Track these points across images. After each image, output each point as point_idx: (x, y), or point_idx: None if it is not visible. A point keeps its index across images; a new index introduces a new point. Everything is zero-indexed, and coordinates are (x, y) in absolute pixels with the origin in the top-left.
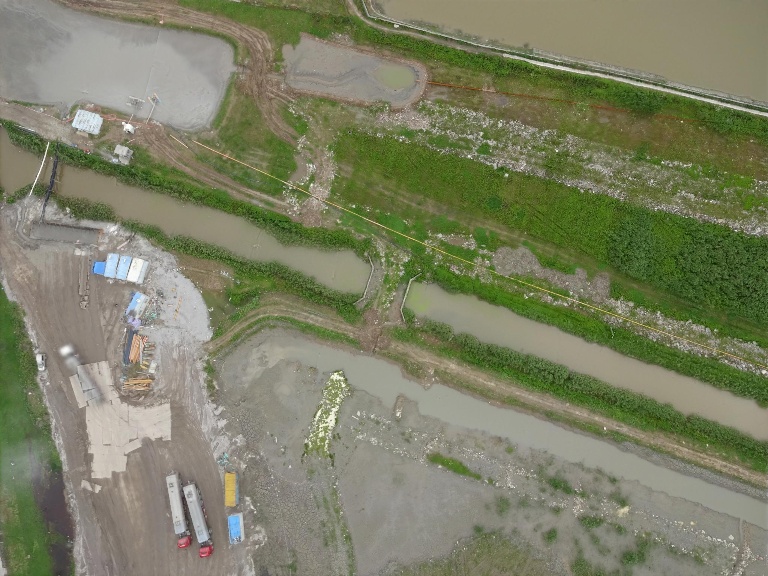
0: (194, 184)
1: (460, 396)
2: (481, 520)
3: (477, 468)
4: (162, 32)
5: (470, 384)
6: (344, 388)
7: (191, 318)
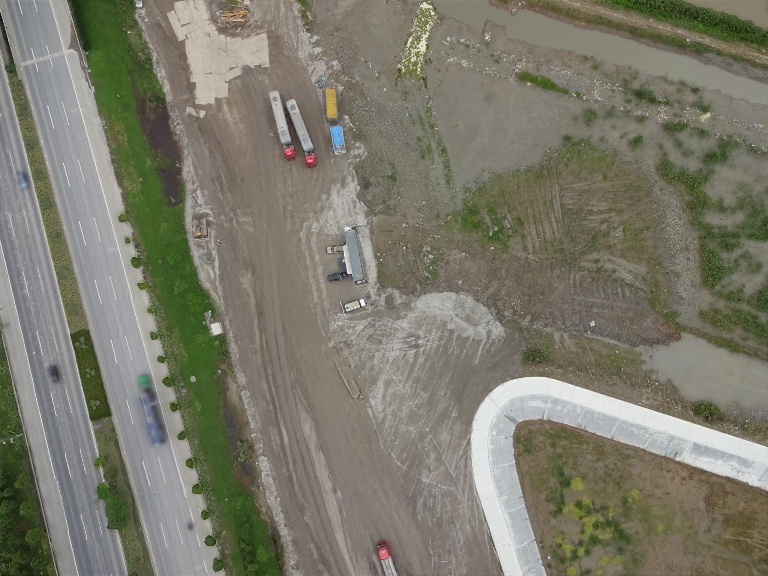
0: None
1: (546, 20)
2: (570, 131)
3: (565, 83)
4: None
5: (556, 5)
6: (433, 16)
7: None
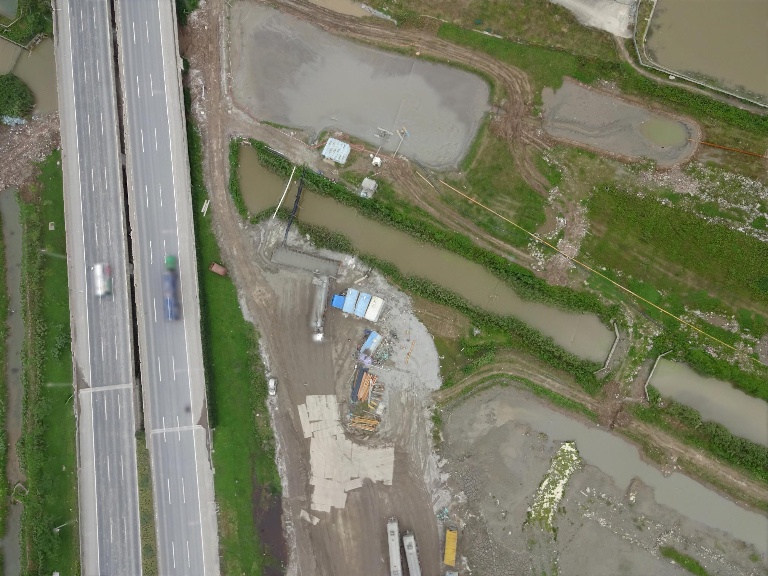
0: (436, 225)
1: (703, 490)
2: None
3: (715, 571)
4: (416, 63)
5: (718, 480)
6: (575, 461)
7: (422, 364)
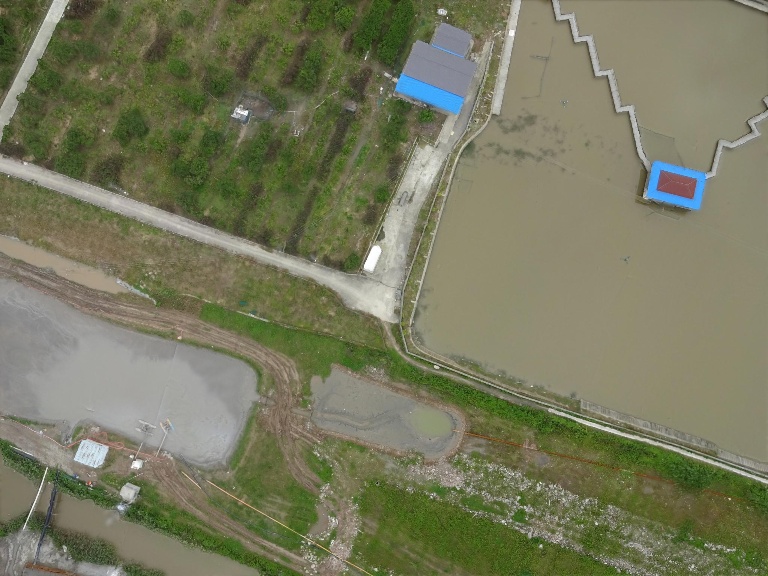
0: (205, 530)
1: None
2: None
3: None
4: (180, 347)
5: None
6: None
7: None
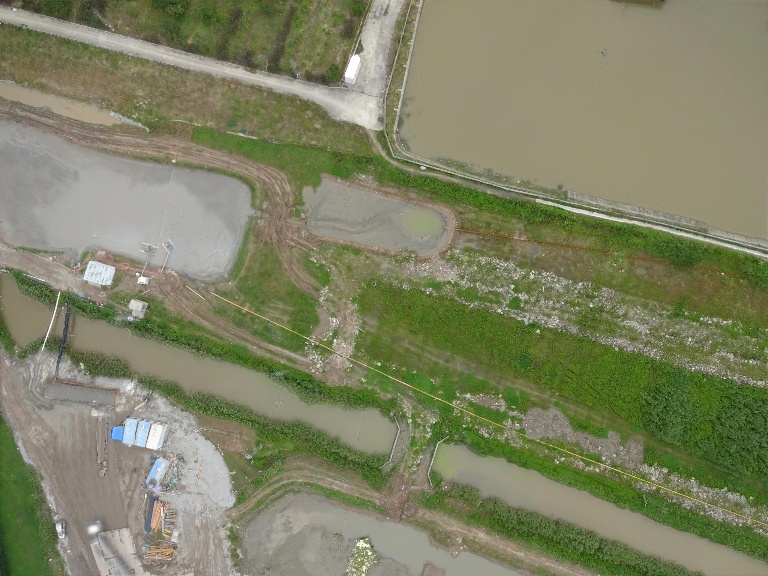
0: (212, 339)
1: (488, 564)
2: None
3: None
4: (175, 171)
5: (499, 554)
6: (370, 556)
7: (213, 483)
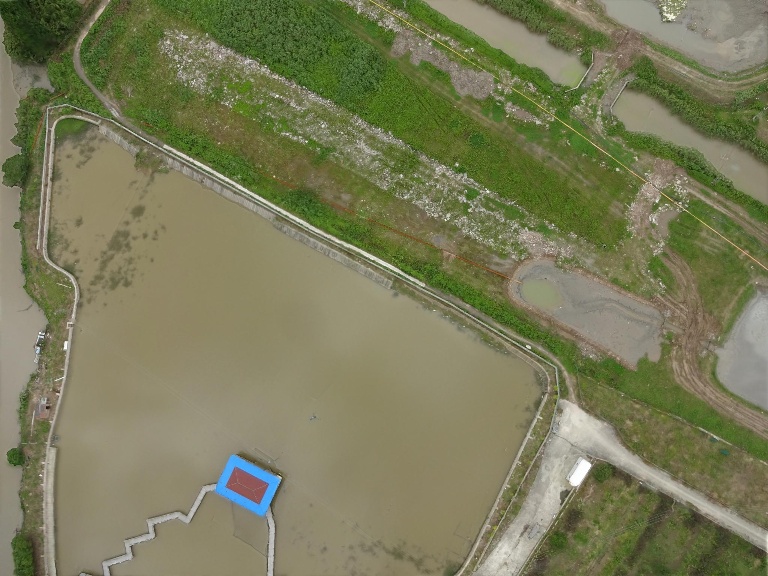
0: None
1: None
2: None
3: None
4: None
5: None
6: (665, 6)
7: None
